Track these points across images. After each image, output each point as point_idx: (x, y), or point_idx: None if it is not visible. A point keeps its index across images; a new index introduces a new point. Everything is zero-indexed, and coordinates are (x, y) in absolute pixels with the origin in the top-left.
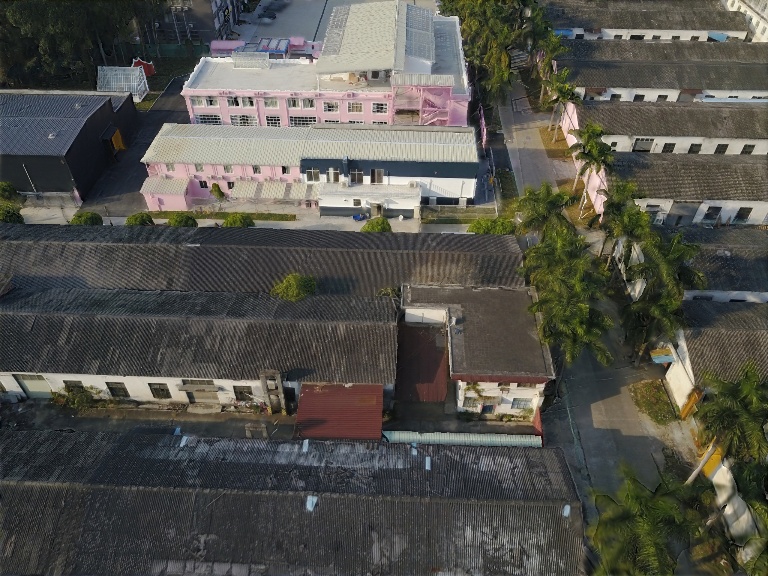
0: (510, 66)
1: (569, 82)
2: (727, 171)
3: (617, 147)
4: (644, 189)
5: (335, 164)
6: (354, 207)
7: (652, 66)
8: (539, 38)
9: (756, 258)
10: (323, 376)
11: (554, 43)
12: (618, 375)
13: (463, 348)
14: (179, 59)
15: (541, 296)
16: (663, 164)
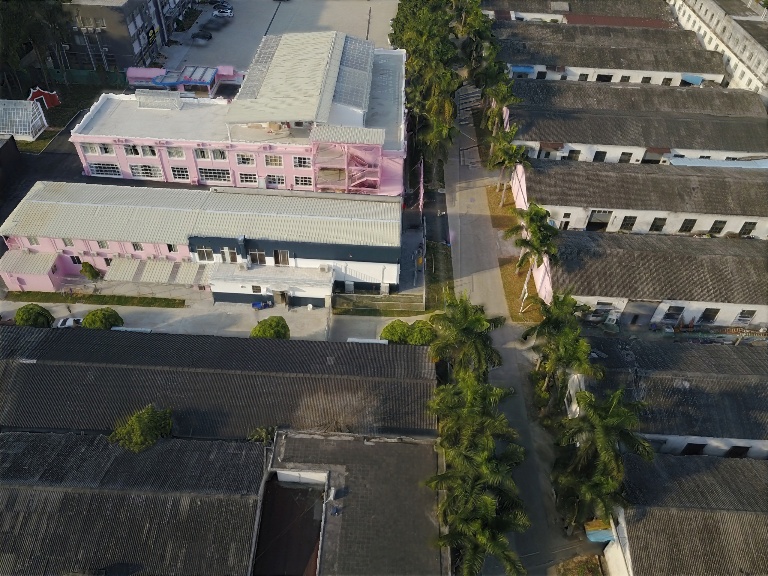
0: (455, 115)
1: (522, 135)
2: (692, 264)
3: (571, 218)
4: (594, 284)
5: (230, 243)
6: (254, 294)
7: (616, 119)
8: (491, 82)
9: (720, 391)
10: (152, 575)
11: (504, 93)
12: (546, 548)
13: (338, 539)
14: (91, 87)
15: (447, 458)
16: (618, 253)
